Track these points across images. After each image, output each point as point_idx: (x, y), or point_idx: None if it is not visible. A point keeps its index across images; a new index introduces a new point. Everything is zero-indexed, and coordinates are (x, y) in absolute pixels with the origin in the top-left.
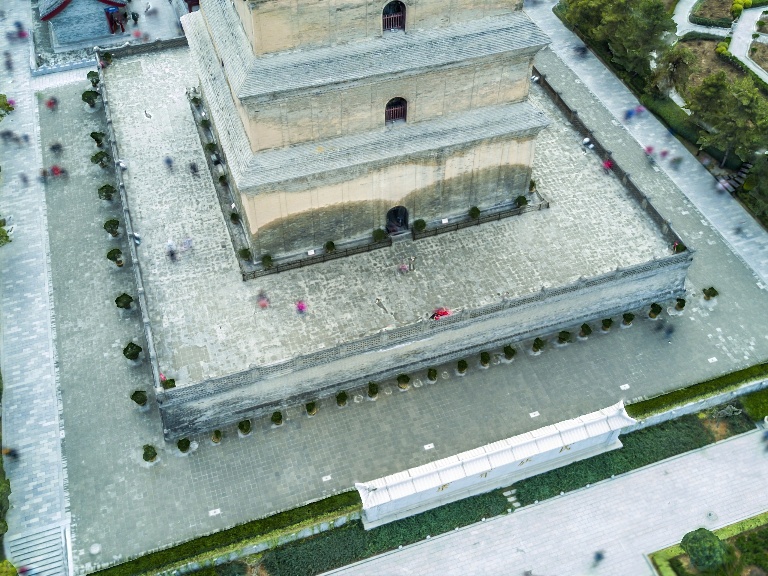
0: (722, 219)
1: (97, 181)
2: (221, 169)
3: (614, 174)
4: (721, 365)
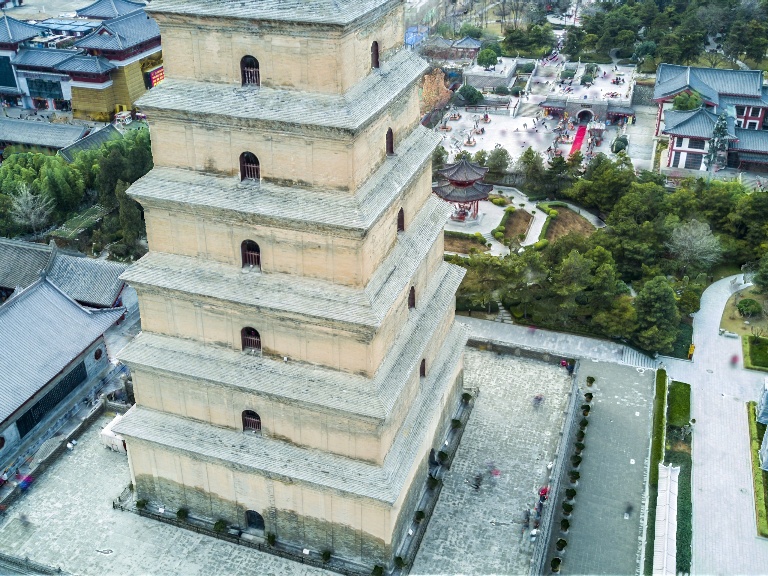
0: (531, 340)
1: None
2: (250, 536)
3: (476, 348)
4: (644, 413)
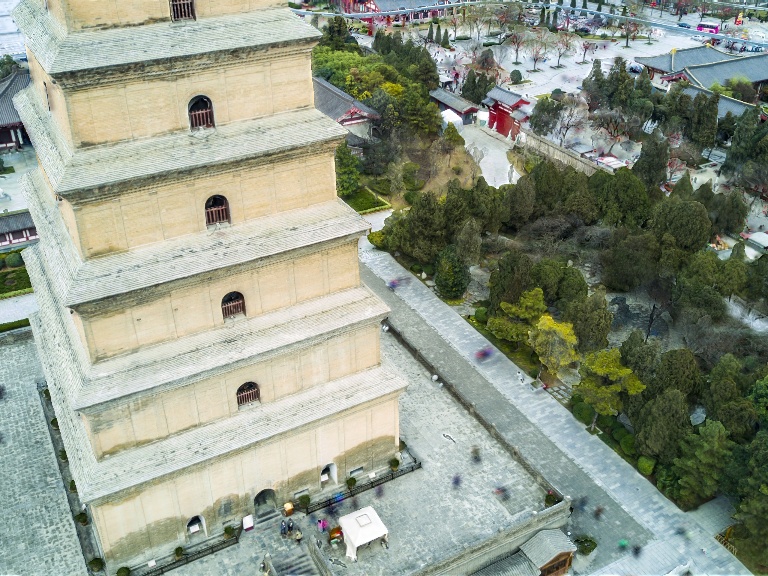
0: None
1: None
2: None
3: None
4: None
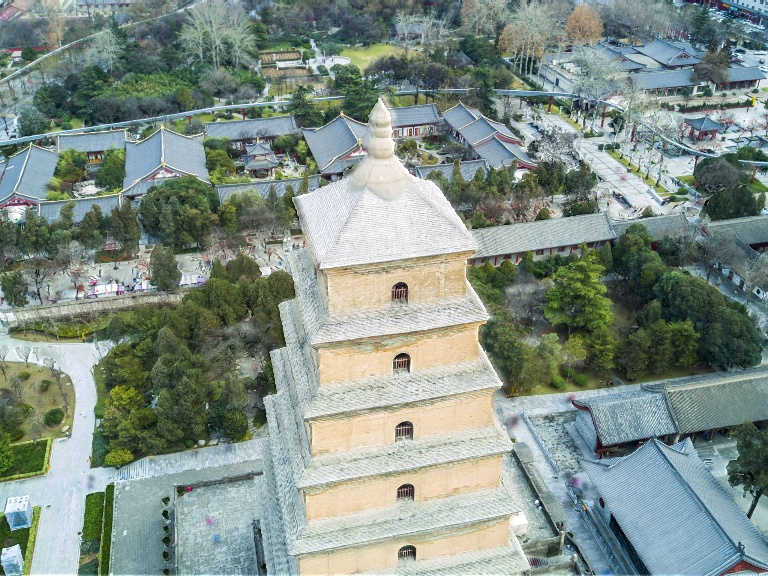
0: None
1: None
2: None
3: None
4: None
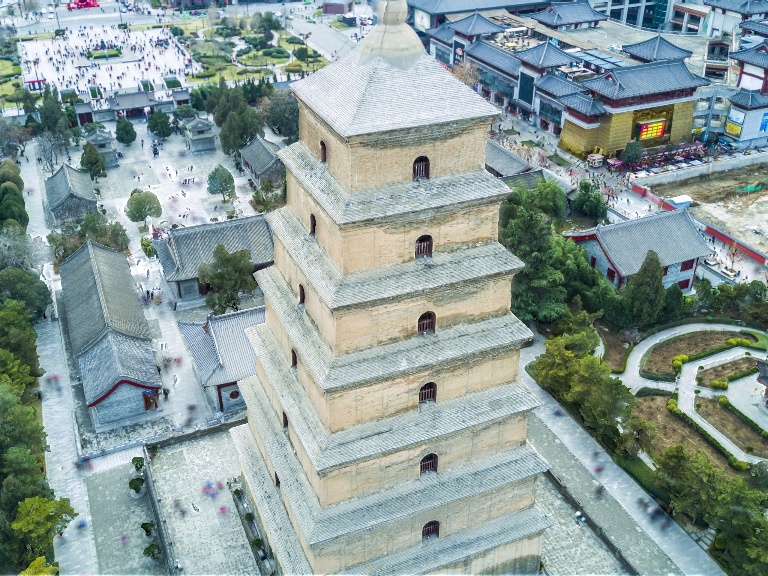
0: None
1: (149, 574)
2: (268, 564)
3: (607, 547)
4: None
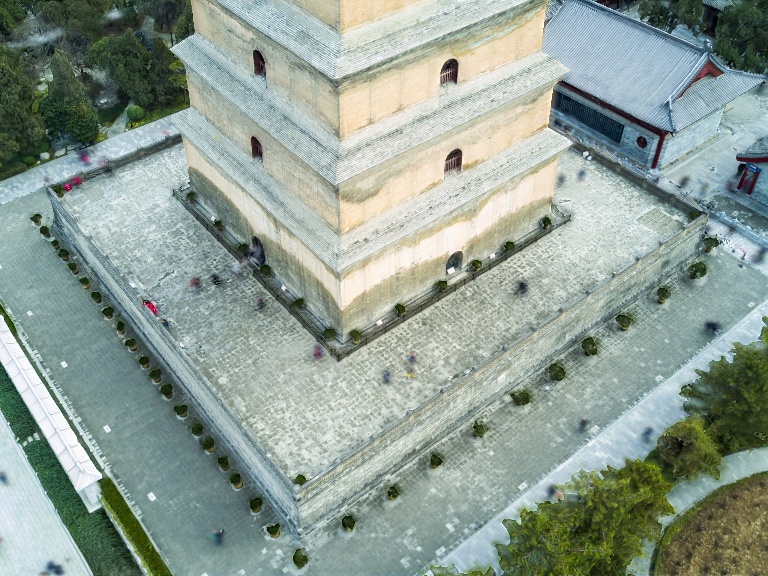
0: None
1: None
2: None
3: None
4: None
